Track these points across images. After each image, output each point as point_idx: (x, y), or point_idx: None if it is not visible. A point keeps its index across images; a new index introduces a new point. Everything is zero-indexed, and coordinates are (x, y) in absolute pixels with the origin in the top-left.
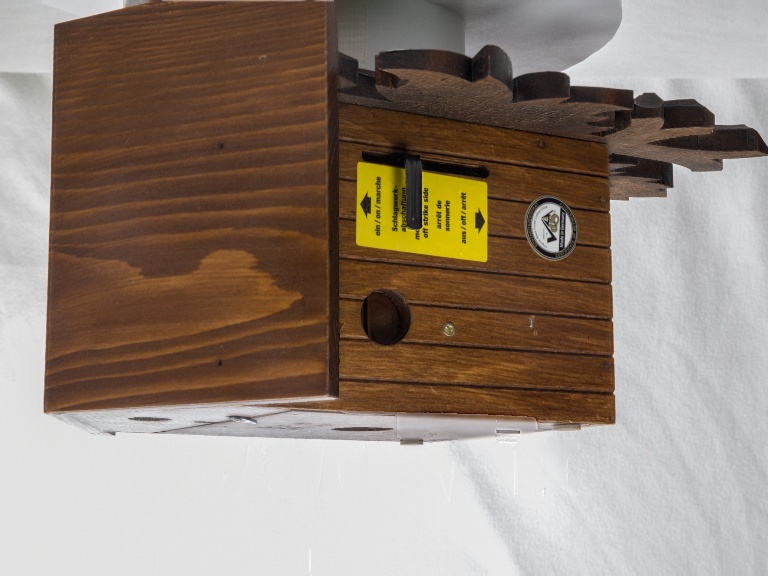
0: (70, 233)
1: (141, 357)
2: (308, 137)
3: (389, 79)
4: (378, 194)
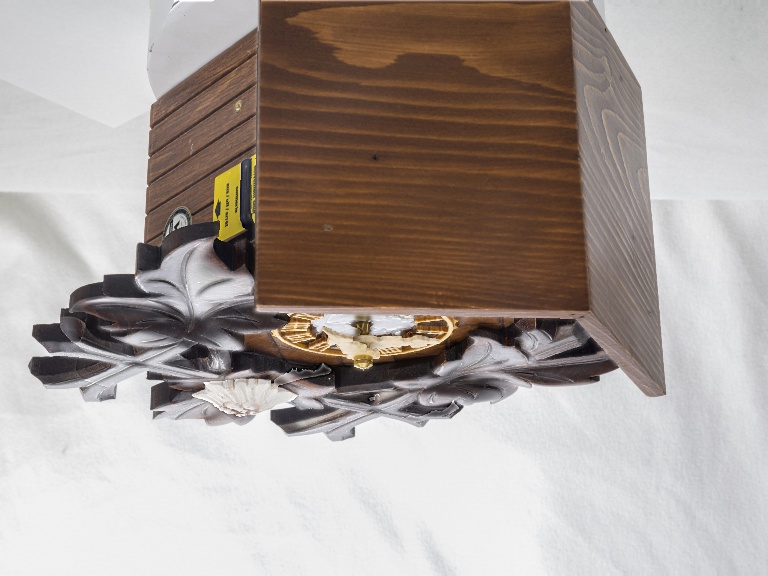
0: (550, 107)
1: None
2: (278, 149)
3: (237, 250)
4: None
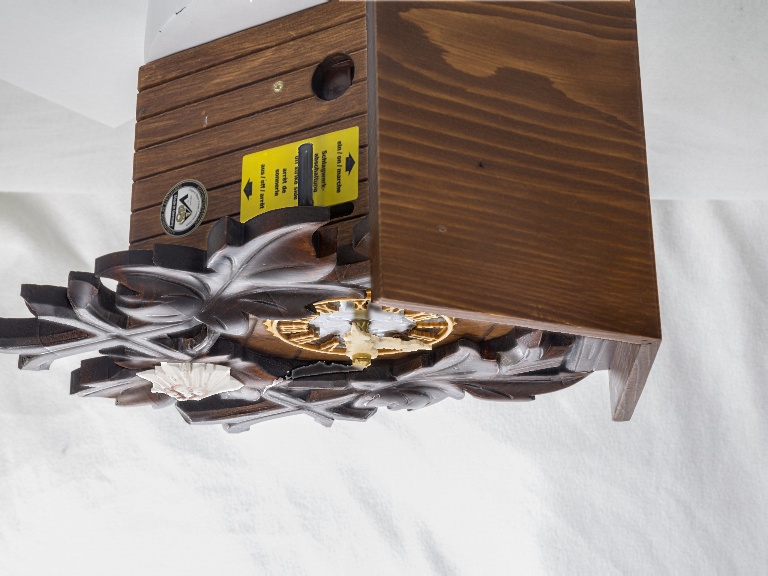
0: (625, 140)
1: (547, 15)
2: (396, 143)
3: (324, 237)
4: (339, 177)
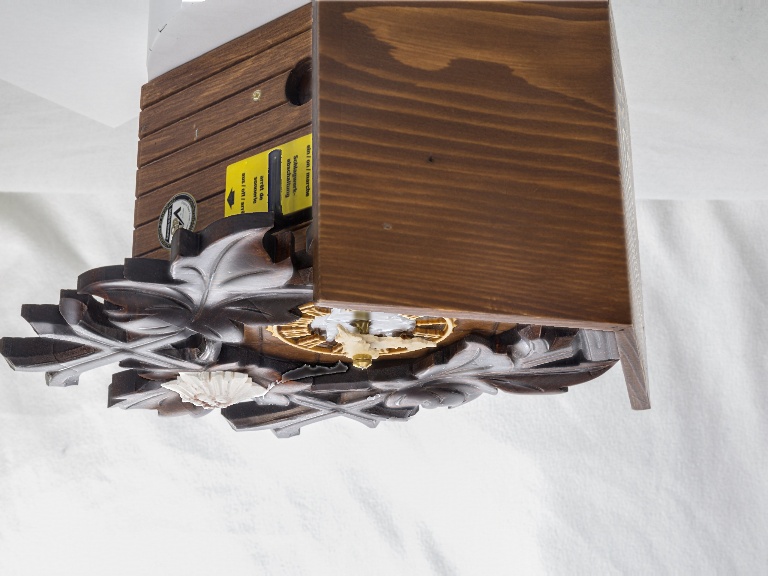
0: (593, 123)
1: (507, 2)
2: (338, 143)
3: (280, 242)
4: (308, 181)
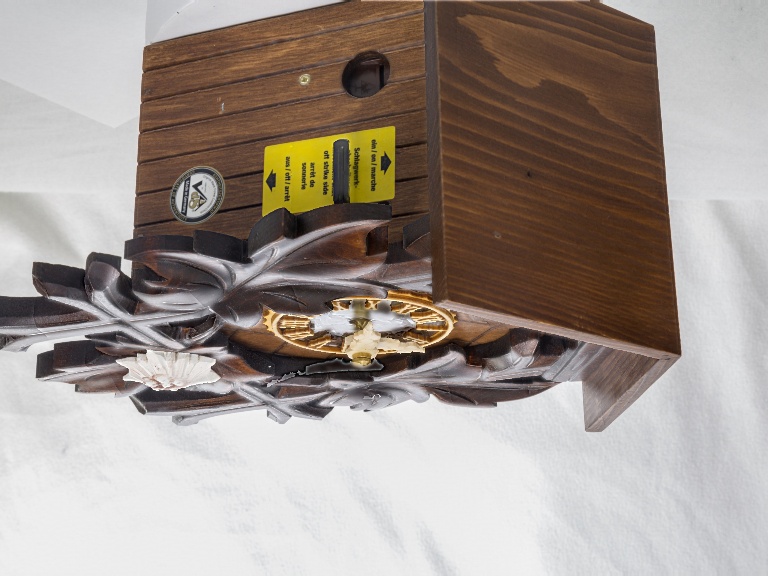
0: (648, 160)
1: (582, 32)
2: (457, 146)
3: (373, 235)
4: (374, 176)
